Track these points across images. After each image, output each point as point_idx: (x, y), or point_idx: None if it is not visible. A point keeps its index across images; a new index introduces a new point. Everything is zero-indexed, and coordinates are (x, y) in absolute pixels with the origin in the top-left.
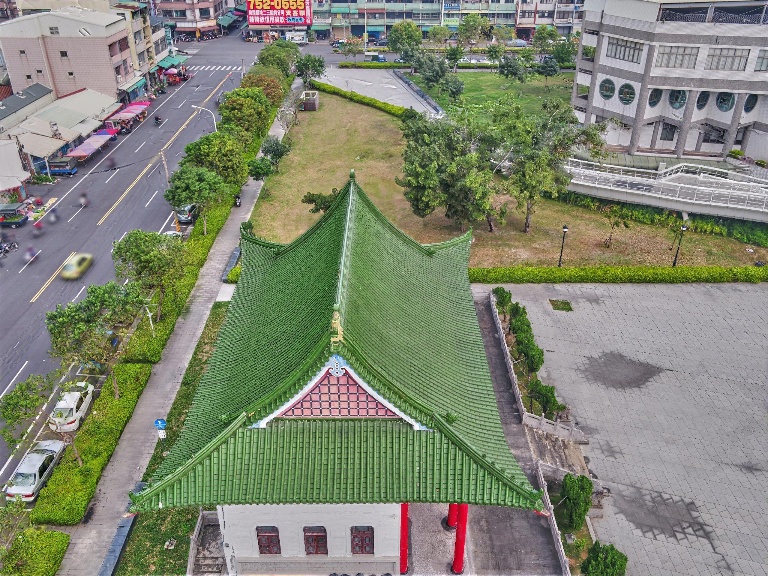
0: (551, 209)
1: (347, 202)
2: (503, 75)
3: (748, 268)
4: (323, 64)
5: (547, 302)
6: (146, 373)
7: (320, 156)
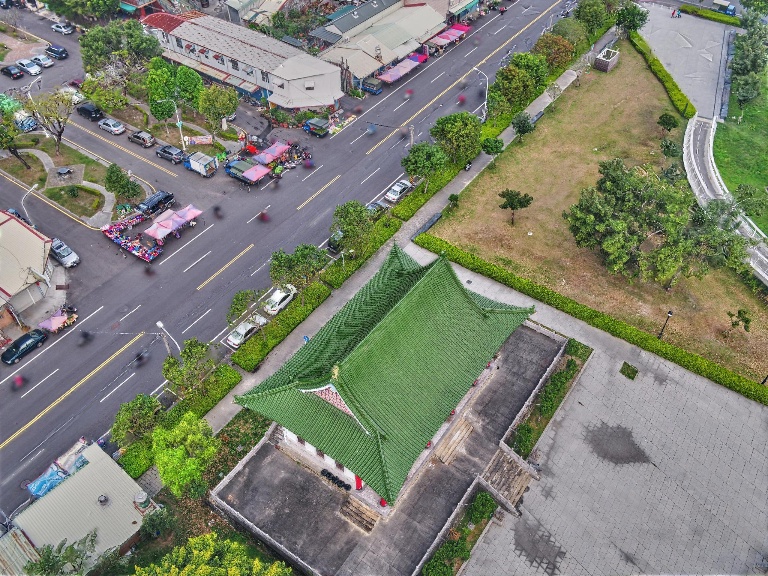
0: (715, 275)
1: None
2: None
3: None
4: (645, 18)
5: (621, 363)
6: (325, 295)
7: (567, 135)
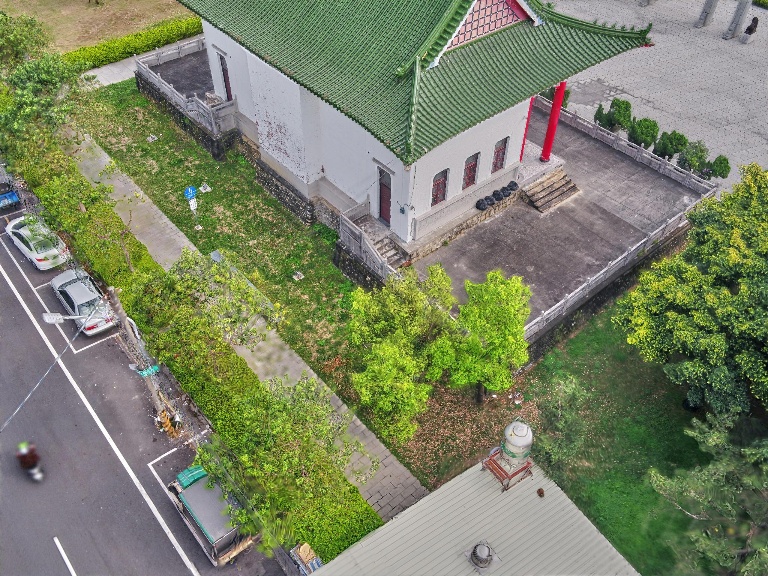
0: None
1: None
2: None
3: None
4: None
5: None
6: None
7: None
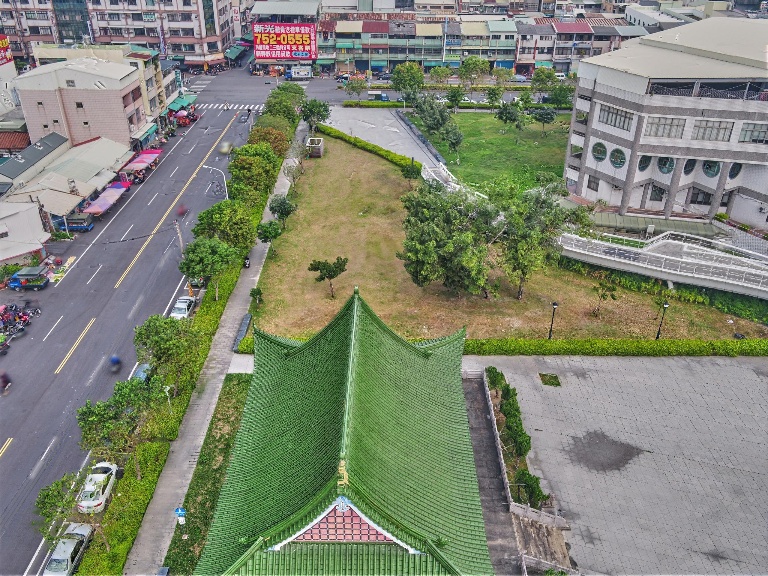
0: None
1: (352, 318)
2: (502, 120)
3: (727, 342)
4: (328, 108)
5: (537, 376)
6: (165, 453)
7: (325, 210)
